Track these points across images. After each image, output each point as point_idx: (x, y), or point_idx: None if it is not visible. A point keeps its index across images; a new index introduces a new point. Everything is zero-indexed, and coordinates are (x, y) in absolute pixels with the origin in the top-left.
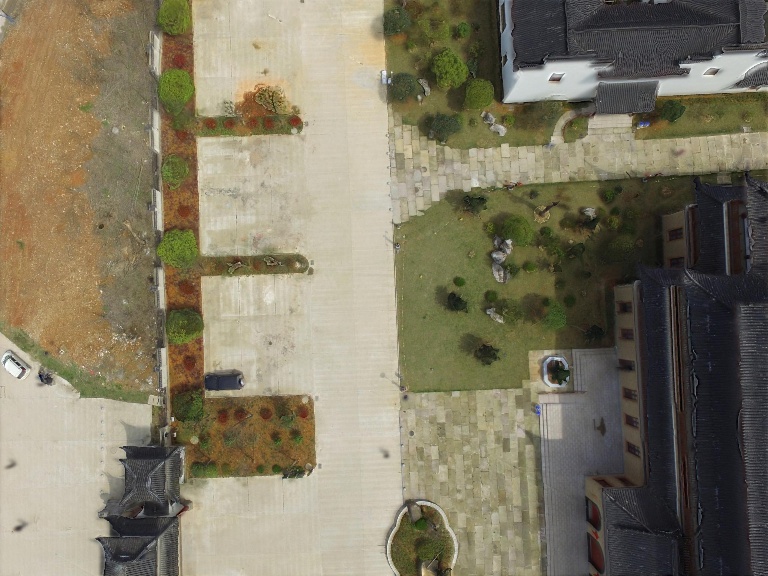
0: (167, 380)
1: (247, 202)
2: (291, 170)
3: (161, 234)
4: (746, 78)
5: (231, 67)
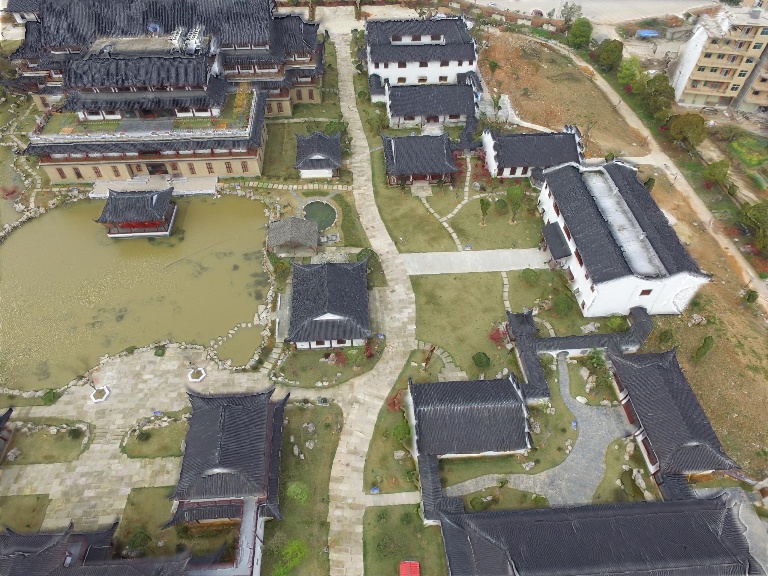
0: (277, 1)
1: (333, 13)
2: (343, 19)
3: (323, 0)
4: (370, 76)
5: (377, 11)
